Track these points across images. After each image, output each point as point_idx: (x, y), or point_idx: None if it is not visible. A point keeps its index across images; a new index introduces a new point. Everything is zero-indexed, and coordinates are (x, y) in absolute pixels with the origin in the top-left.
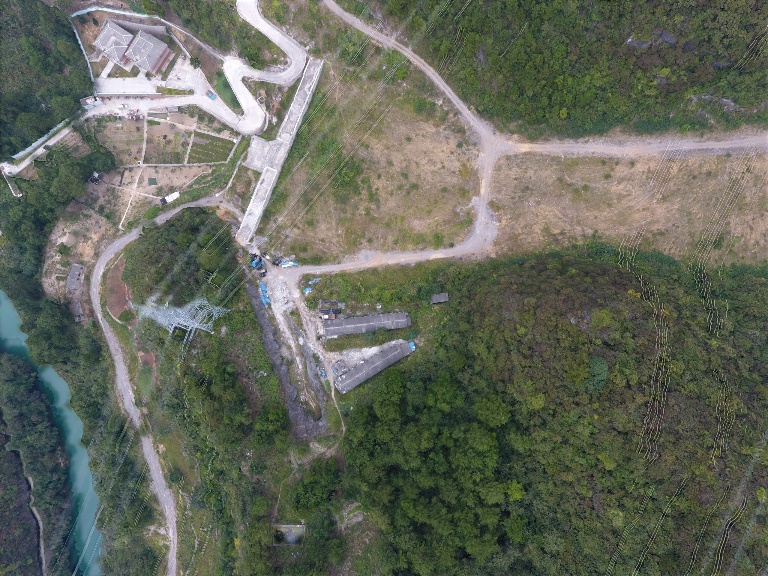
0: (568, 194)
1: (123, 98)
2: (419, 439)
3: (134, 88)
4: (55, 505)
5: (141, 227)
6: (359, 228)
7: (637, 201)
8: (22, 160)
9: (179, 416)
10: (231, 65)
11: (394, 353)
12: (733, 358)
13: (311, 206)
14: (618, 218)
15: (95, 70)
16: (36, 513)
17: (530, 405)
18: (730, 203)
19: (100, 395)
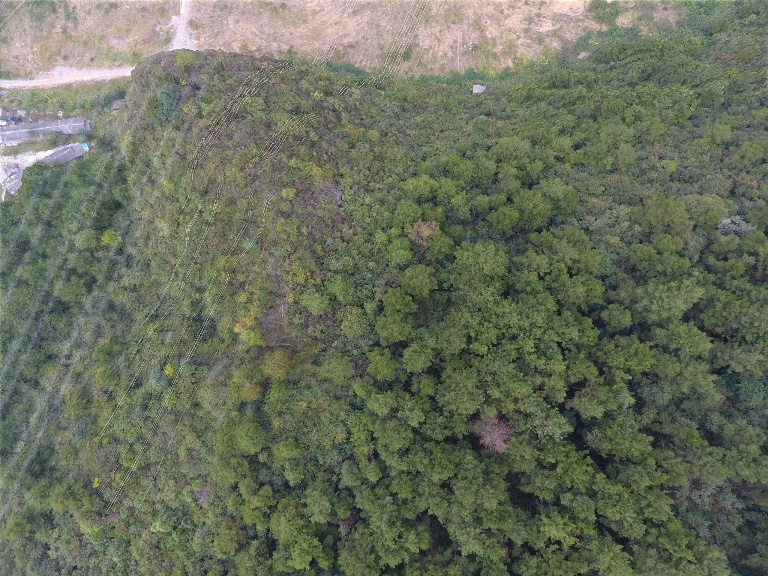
0: (266, 12)
1: None
2: (37, 204)
3: None
4: None
5: None
6: (55, 46)
7: (329, 16)
8: None
9: None
10: None
11: (64, 152)
12: (338, 110)
13: (5, 24)
14: (312, 33)
15: None
16: None
17: (124, 151)
18: (417, 15)
19: None
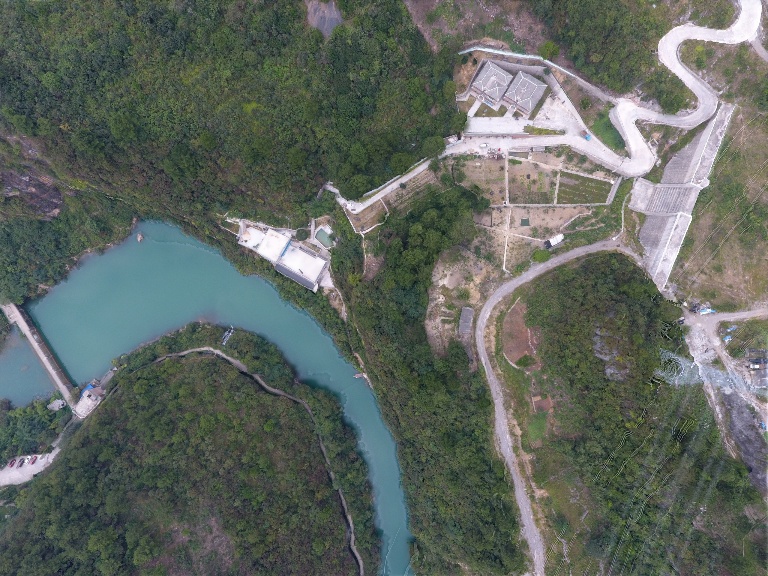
0: None
1: (484, 137)
2: None
3: (501, 127)
4: (371, 544)
5: (531, 270)
6: (766, 274)
7: None
8: (369, 197)
9: (594, 465)
10: (625, 107)
11: None
12: None
13: (717, 251)
14: None
15: (462, 109)
16: (356, 552)
17: None
18: None
19: (485, 440)
